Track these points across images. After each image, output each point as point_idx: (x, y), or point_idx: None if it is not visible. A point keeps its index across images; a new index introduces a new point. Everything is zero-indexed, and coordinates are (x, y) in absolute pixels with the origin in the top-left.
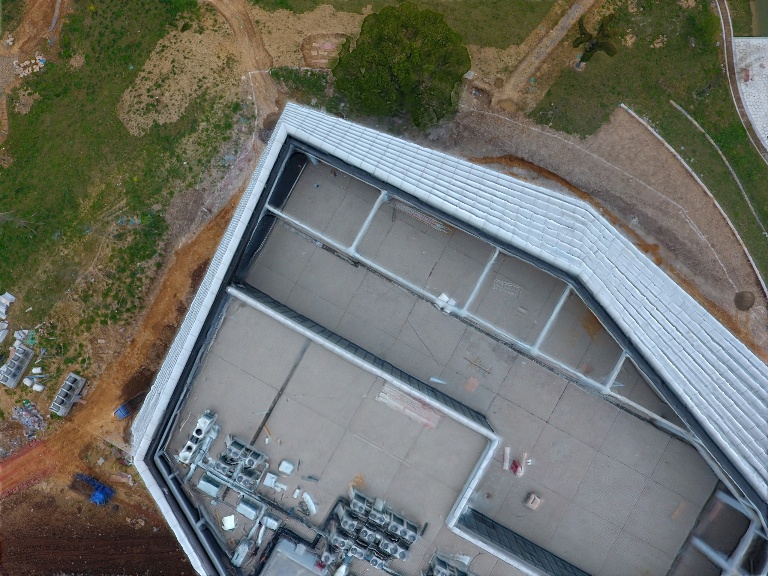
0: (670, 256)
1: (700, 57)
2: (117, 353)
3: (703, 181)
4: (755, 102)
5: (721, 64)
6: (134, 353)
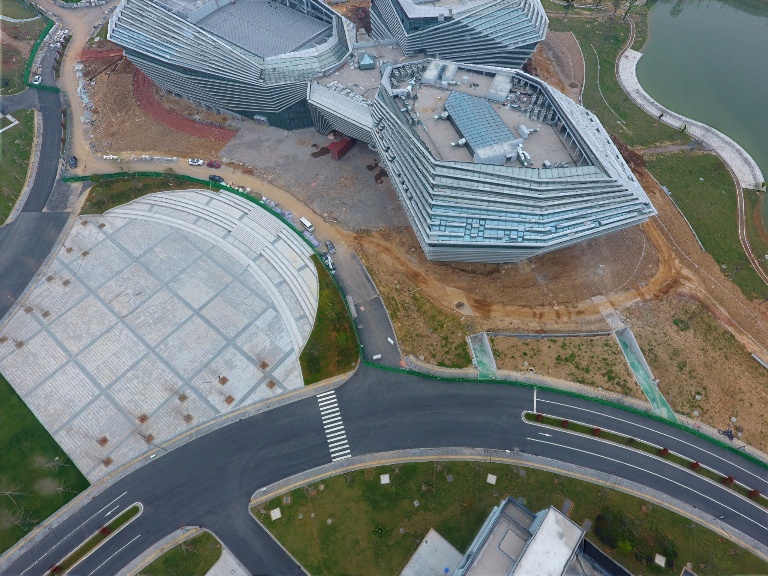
0: (556, 65)
1: (612, 44)
2: (362, 2)
3: (585, 59)
4: (625, 63)
5: (619, 50)
6: (366, 4)
